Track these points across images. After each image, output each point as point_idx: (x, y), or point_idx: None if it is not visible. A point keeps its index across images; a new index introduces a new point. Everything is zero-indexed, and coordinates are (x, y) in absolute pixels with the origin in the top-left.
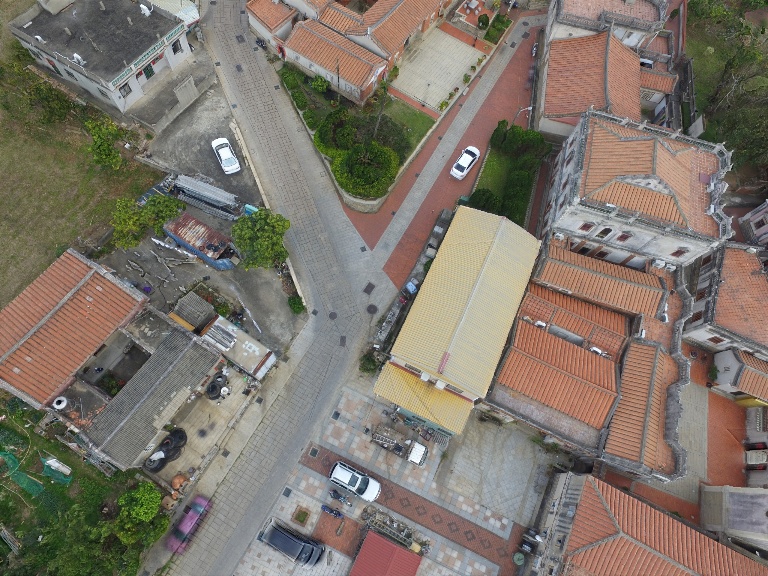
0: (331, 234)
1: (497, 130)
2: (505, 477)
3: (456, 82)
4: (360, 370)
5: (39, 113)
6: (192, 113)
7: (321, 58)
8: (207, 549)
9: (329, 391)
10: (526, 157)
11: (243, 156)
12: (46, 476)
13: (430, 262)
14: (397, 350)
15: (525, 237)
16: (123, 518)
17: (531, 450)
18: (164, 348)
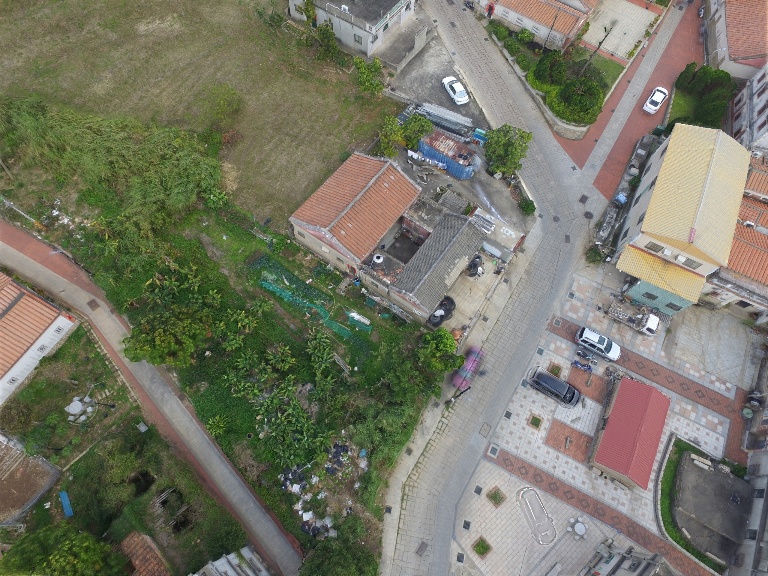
0: (546, 155)
1: (686, 72)
2: (724, 351)
3: (637, 37)
4: (587, 261)
5: (301, 56)
6: (421, 58)
7: (531, 12)
8: (482, 389)
9: (562, 277)
10: (719, 91)
11: (468, 91)
12: (352, 324)
13: (637, 178)
14: (647, 227)
15: (738, 147)
16: (432, 349)
17: (743, 331)
18: (441, 228)
